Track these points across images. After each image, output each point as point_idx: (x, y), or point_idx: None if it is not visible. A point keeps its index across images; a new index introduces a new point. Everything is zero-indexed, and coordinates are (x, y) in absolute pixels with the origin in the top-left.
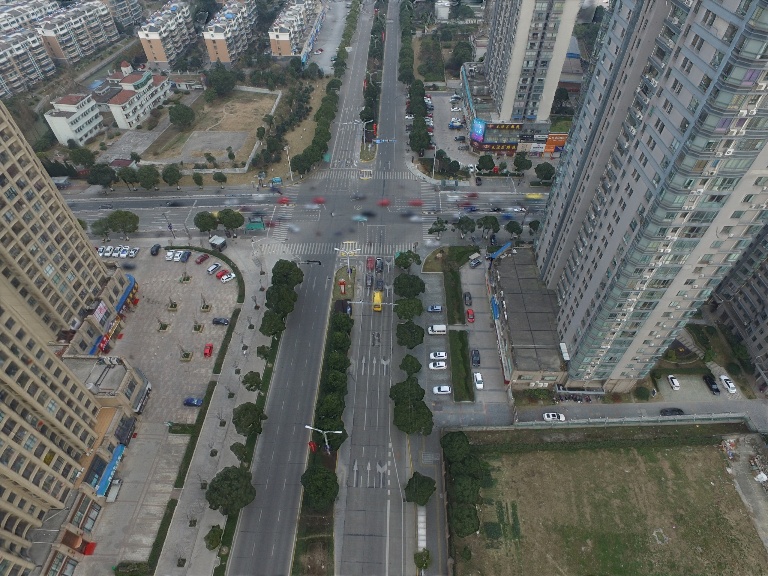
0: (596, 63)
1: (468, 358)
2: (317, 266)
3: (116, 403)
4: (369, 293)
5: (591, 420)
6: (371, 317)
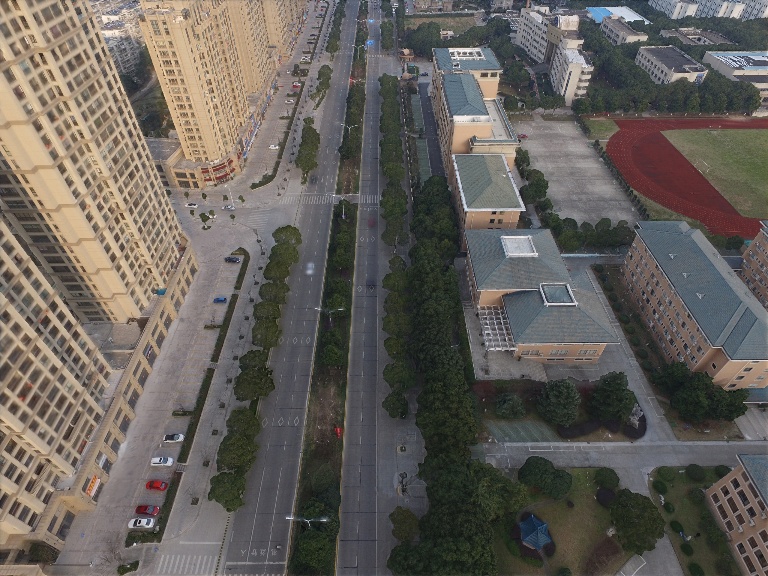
0: None
1: (404, 8)
2: (353, 0)
3: (304, 3)
4: (372, 3)
5: (438, 12)
6: (373, 6)
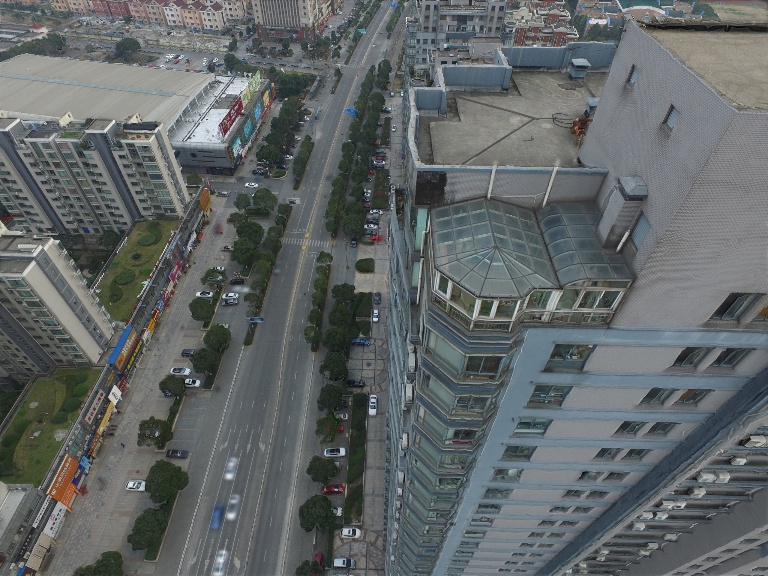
0: (448, 530)
1: None
2: None
3: None
4: None
5: None
6: None
